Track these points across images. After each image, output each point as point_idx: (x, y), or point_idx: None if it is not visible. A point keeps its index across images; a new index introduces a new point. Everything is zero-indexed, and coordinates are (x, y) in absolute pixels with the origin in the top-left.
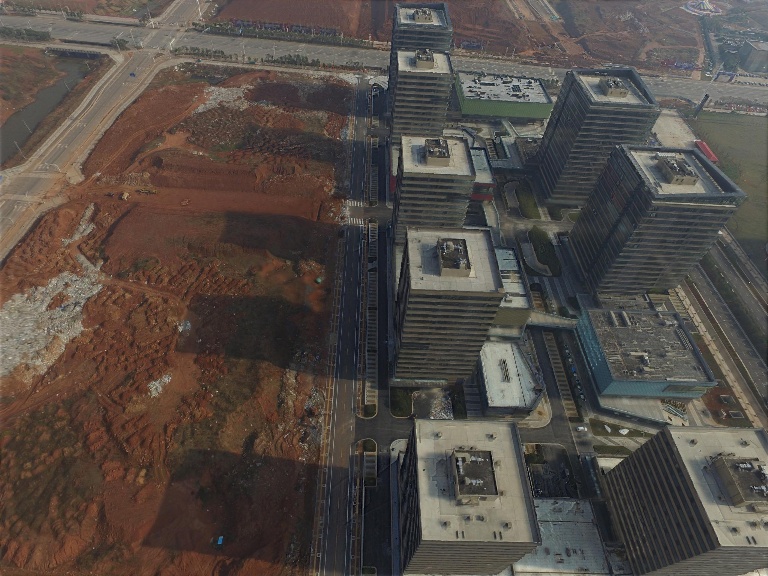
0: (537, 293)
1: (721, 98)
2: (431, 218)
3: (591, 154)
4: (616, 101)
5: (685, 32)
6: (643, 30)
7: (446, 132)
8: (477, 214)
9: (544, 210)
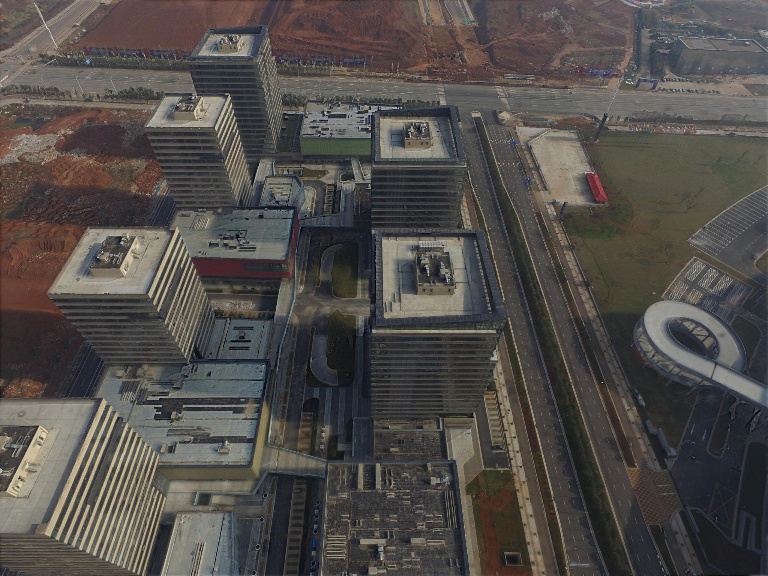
0: (310, 414)
1: (633, 113)
2: (129, 338)
3: (399, 219)
4: (413, 155)
5: (615, 29)
6: (566, 30)
7: (271, 182)
8: (275, 294)
9: (364, 284)
